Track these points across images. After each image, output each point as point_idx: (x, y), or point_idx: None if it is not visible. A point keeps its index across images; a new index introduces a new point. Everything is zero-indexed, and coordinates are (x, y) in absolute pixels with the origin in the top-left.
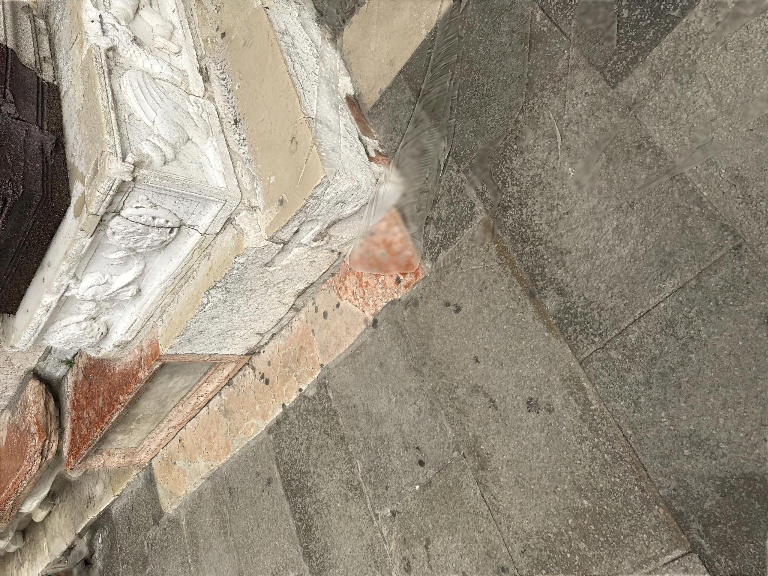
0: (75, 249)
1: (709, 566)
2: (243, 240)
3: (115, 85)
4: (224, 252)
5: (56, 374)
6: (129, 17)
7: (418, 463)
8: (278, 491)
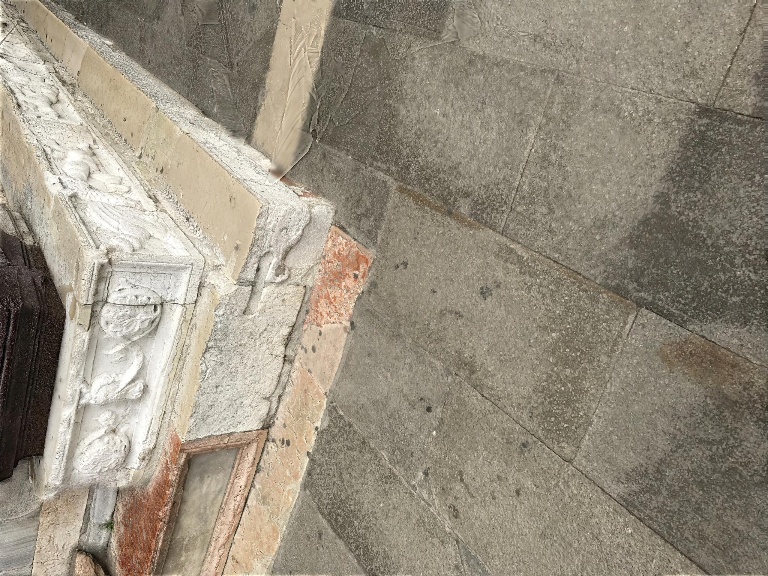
0: (77, 346)
1: (656, 309)
2: (216, 291)
3: (81, 213)
4: (205, 313)
5: (100, 543)
6: (83, 178)
7: (426, 411)
8: (330, 537)
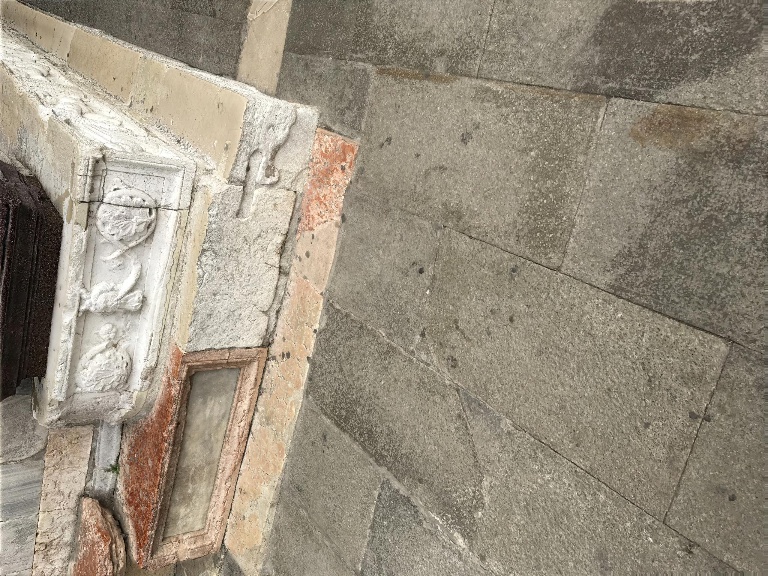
0: (76, 246)
1: (624, 94)
2: (209, 191)
3: None
4: (199, 215)
5: (106, 490)
6: None
7: (419, 273)
8: (334, 434)
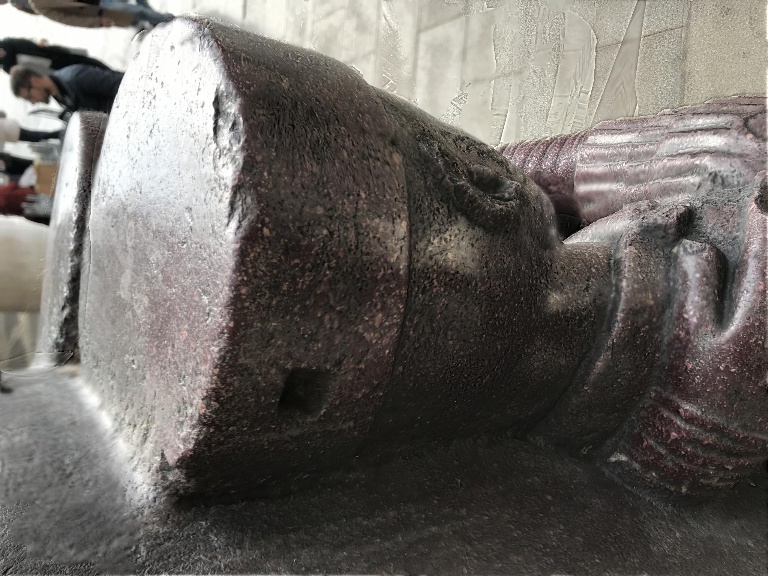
0: None
1: None
2: None
3: None
4: None
5: None
6: None
7: None
8: None
